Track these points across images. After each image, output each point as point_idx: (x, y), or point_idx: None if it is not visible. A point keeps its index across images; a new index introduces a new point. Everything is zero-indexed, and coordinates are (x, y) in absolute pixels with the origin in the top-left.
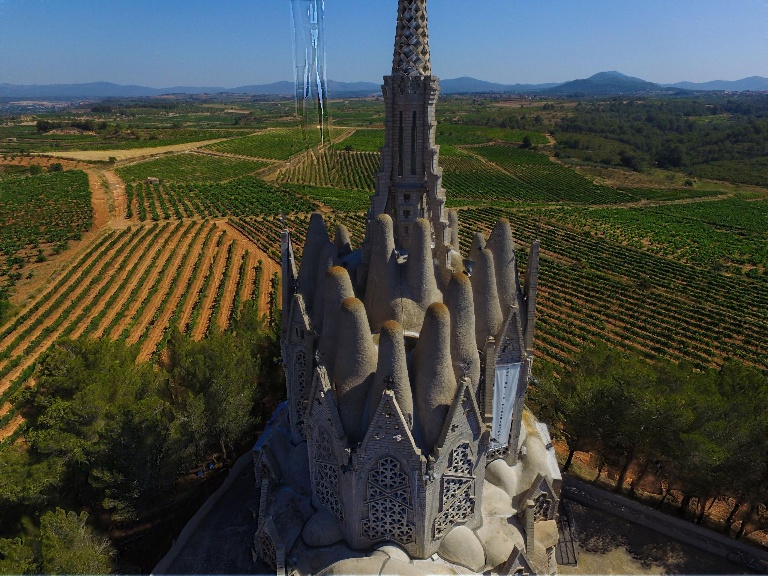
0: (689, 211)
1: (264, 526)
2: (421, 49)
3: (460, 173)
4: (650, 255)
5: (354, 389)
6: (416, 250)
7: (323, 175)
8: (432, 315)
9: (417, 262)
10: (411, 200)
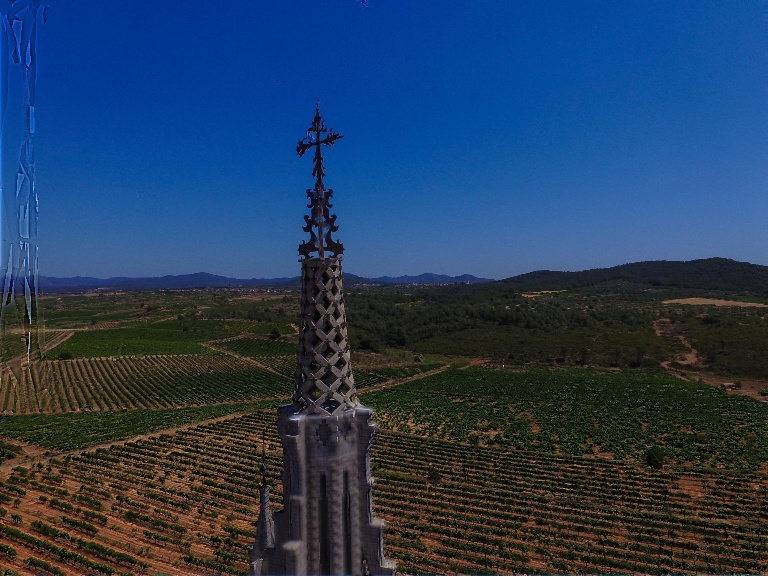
0: (428, 385)
1: None
2: (346, 369)
3: (214, 373)
4: (422, 439)
5: None
6: None
7: (27, 399)
8: None
9: None
10: None
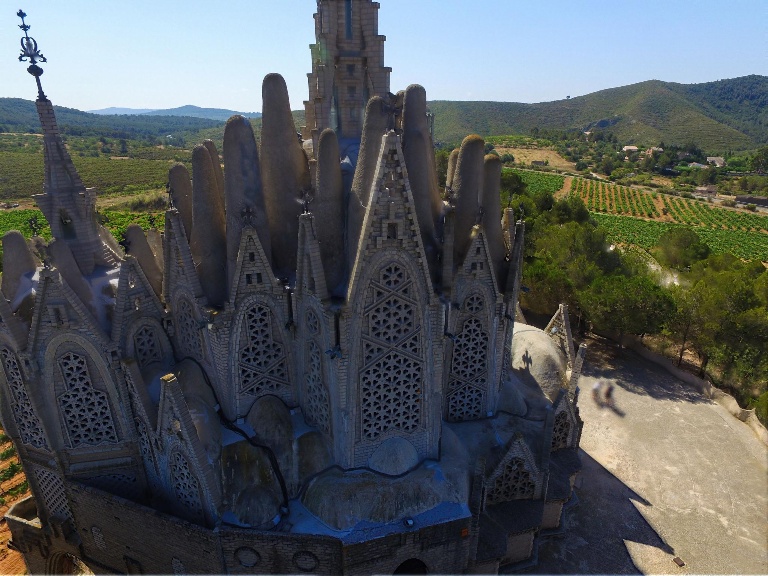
0: None
1: None
2: None
3: None
4: None
5: None
6: None
7: None
8: None
9: None
10: None
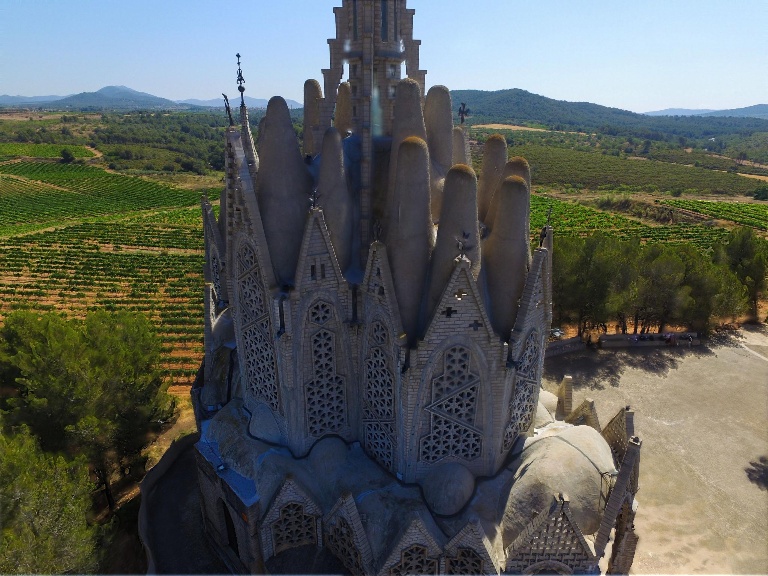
0: None
1: (408, 537)
2: None
3: None
4: None
5: (479, 278)
6: (445, 120)
7: None
8: (523, 167)
9: (448, 134)
10: (397, 73)
